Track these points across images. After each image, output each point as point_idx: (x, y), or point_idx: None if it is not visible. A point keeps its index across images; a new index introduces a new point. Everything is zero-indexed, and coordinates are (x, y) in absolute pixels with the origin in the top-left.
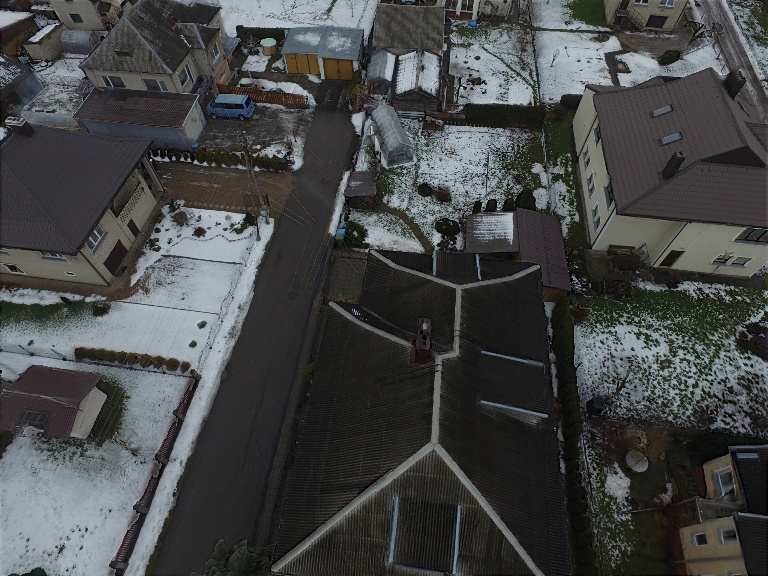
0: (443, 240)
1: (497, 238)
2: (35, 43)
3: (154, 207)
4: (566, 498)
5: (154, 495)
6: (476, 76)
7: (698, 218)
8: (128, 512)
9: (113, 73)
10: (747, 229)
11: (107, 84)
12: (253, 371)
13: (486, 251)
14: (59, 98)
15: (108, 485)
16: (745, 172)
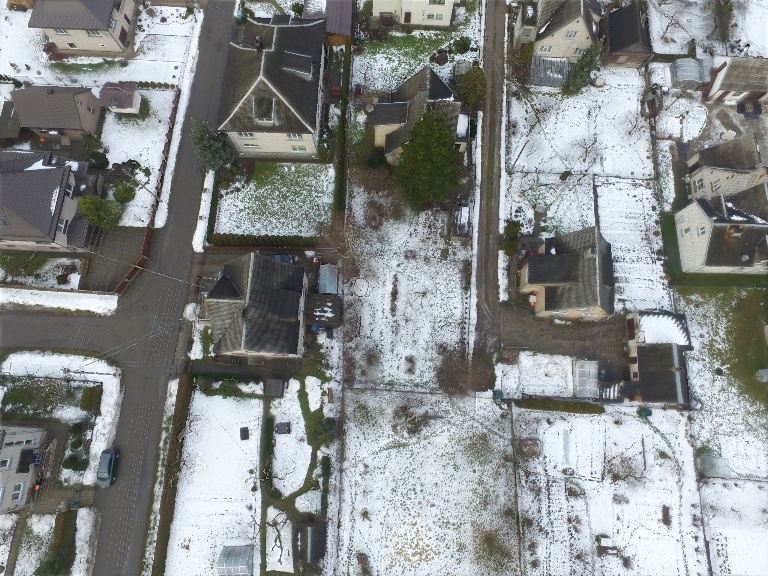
0: (295, 16)
1: (317, 11)
2: None
3: (134, 7)
4: (339, 124)
5: (172, 135)
6: None
7: None
8: (163, 142)
9: None
10: None
11: None
12: (205, 86)
13: (311, 18)
14: None
15: (152, 133)
16: None
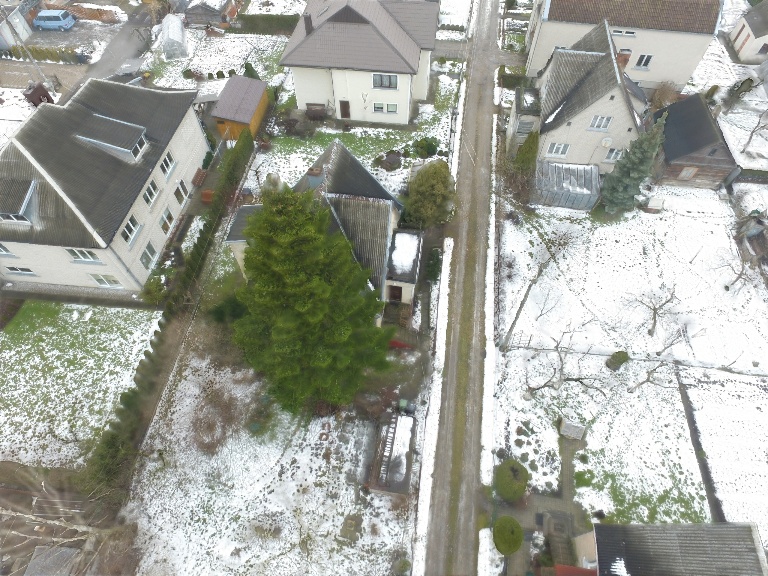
0: None
1: (210, 94)
2: None
3: None
4: None
5: None
6: (268, 0)
7: (333, 65)
8: None
9: None
10: (377, 76)
11: None
12: None
13: (198, 102)
14: None
15: None
16: (358, 28)
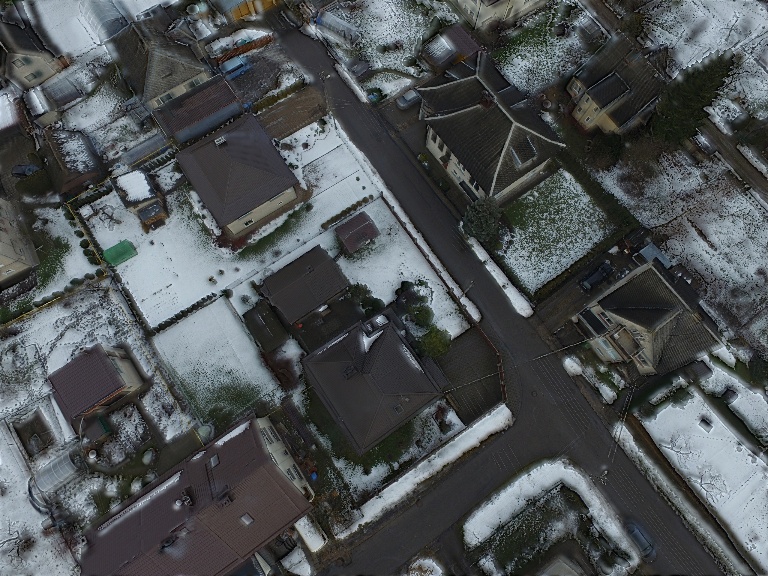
0: (414, 69)
1: (442, 51)
2: (43, 114)
3: None
4: None
5: None
6: None
7: None
8: (410, 249)
9: (164, 93)
10: None
11: (158, 104)
12: (398, 178)
13: (443, 60)
14: (111, 138)
15: (393, 249)
16: None
